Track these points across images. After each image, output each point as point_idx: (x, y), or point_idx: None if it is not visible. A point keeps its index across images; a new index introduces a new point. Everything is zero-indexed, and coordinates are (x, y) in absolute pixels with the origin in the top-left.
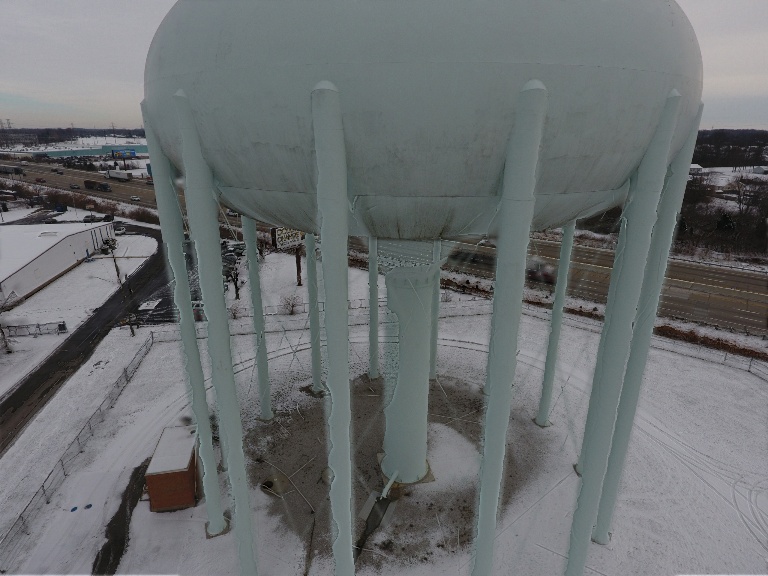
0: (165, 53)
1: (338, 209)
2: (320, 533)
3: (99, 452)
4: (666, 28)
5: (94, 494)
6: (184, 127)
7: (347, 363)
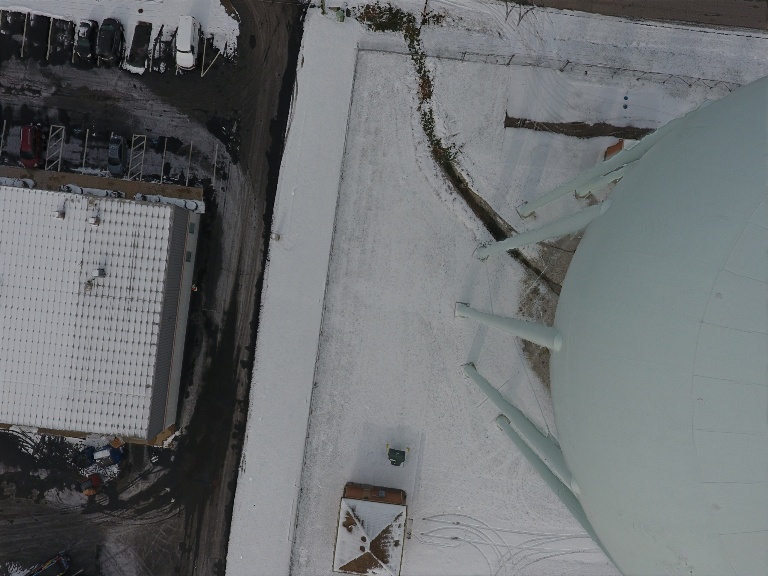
0: (767, 79)
1: (568, 224)
2: (558, 253)
3: (685, 99)
4: (612, 500)
5: (637, 107)
6: (686, 115)
7: (536, 240)
